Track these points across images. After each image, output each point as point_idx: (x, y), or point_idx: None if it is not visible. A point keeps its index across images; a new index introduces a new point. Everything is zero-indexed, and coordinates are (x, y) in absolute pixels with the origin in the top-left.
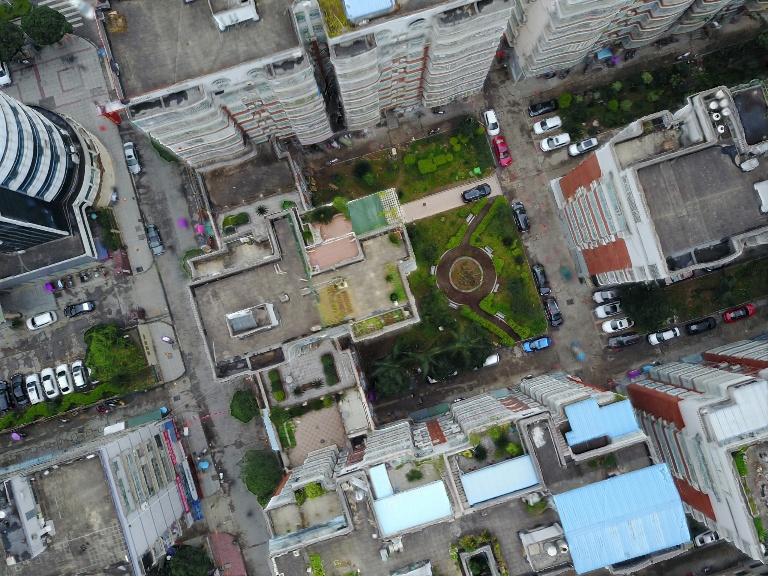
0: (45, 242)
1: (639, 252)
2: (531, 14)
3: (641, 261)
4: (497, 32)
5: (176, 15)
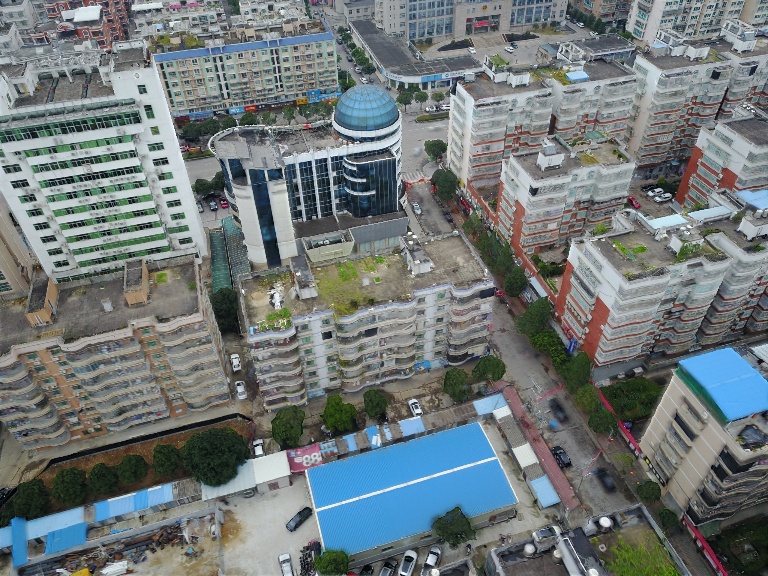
0: (383, 214)
1: (738, 161)
2: (636, 126)
3: (741, 164)
4: (630, 104)
5: None
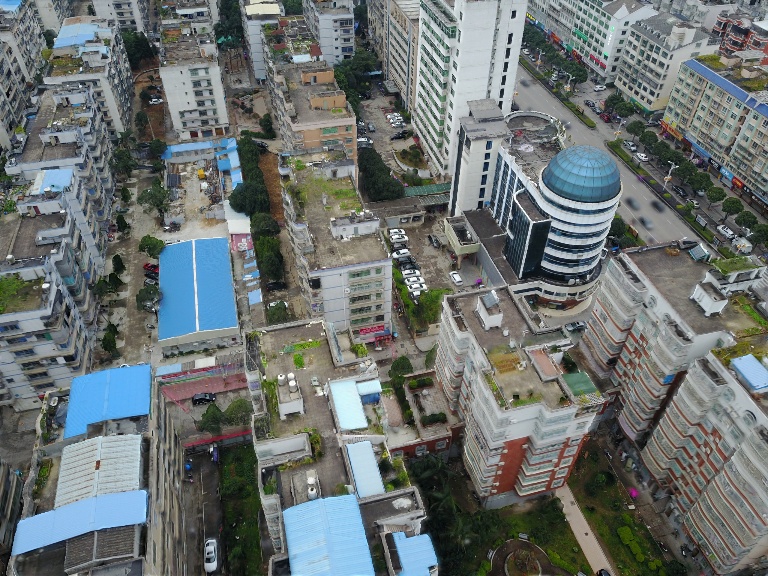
0: (513, 268)
1: None
2: None
3: None
4: None
5: (690, 278)
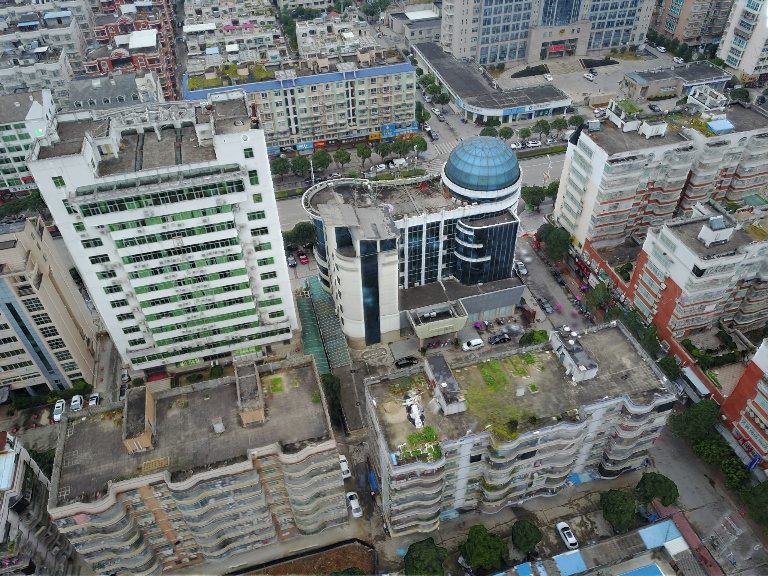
0: (495, 280)
1: None
2: None
3: None
4: None
5: None
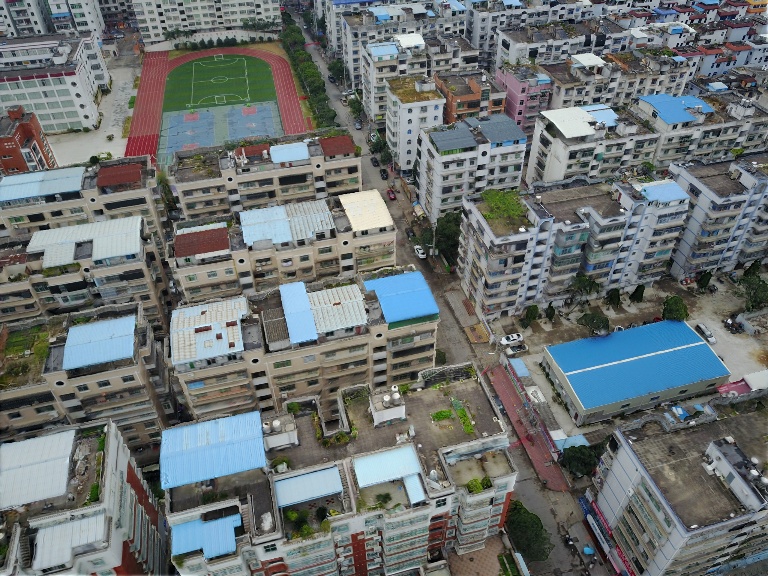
0: None
1: None
2: None
3: None
4: None
5: None
